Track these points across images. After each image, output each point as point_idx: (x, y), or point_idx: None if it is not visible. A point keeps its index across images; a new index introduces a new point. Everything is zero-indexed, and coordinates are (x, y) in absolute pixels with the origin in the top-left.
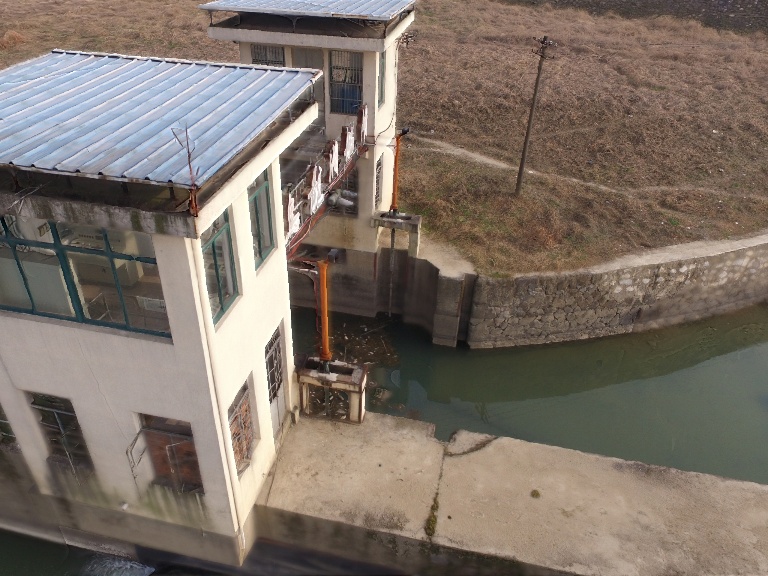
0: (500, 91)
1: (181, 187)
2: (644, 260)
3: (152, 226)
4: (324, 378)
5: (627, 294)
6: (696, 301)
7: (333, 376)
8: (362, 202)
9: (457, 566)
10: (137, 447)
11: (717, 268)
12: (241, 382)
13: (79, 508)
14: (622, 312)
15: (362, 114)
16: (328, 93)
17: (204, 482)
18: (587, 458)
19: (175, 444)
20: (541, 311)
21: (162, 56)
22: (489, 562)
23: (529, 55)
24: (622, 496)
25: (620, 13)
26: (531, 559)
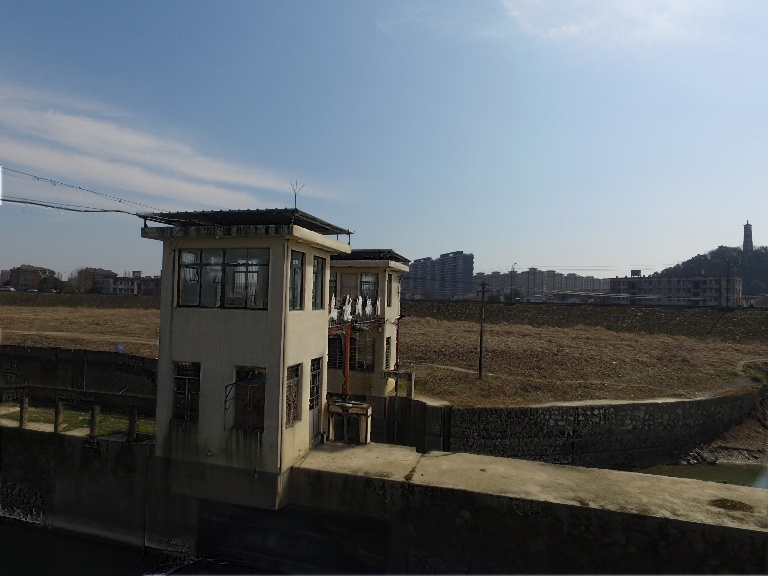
0: (472, 347)
1: (290, 210)
2: (566, 404)
3: (273, 231)
4: (344, 405)
5: (559, 427)
6: (614, 441)
7: (350, 405)
8: (377, 361)
9: (427, 506)
10: (230, 395)
11: (621, 415)
12: (296, 361)
13: (176, 467)
14: (559, 443)
15: (377, 299)
16: (359, 295)
17: (265, 419)
18: (520, 461)
19: (254, 385)
20: (499, 435)
21: None
22: (449, 496)
23: (491, 336)
24: (544, 473)
25: (552, 326)
26: (477, 490)
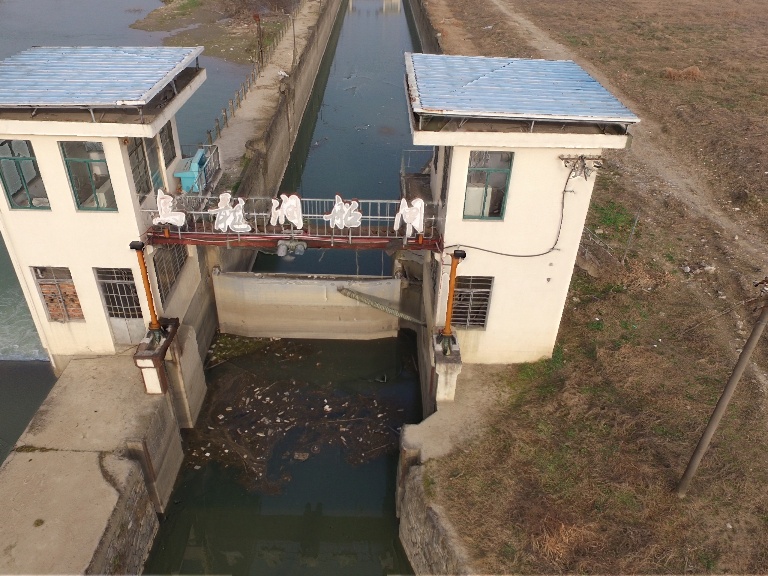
0: None
1: None
2: None
3: None
4: None
5: None
6: None
7: (145, 340)
8: None
9: None
10: None
11: None
12: (50, 263)
13: None
14: None
15: (401, 202)
16: None
17: None
18: (76, 573)
19: None
20: None
21: (767, 132)
22: None
23: None
24: None
25: None
26: None
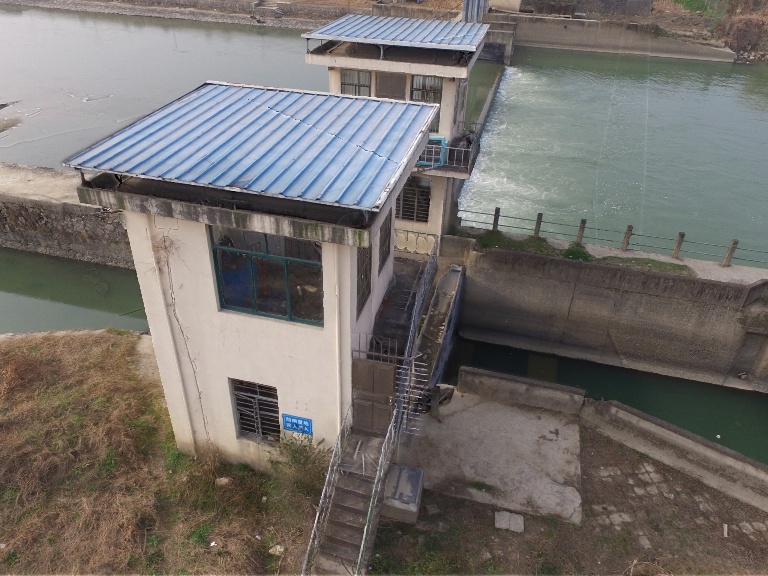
0: None
1: None
2: None
3: None
4: None
5: None
6: None
7: None
8: None
9: None
10: None
11: None
12: None
13: None
14: None
15: None
16: None
17: None
18: None
19: None
20: None
21: None
22: None
23: None
24: None
25: None
26: None
